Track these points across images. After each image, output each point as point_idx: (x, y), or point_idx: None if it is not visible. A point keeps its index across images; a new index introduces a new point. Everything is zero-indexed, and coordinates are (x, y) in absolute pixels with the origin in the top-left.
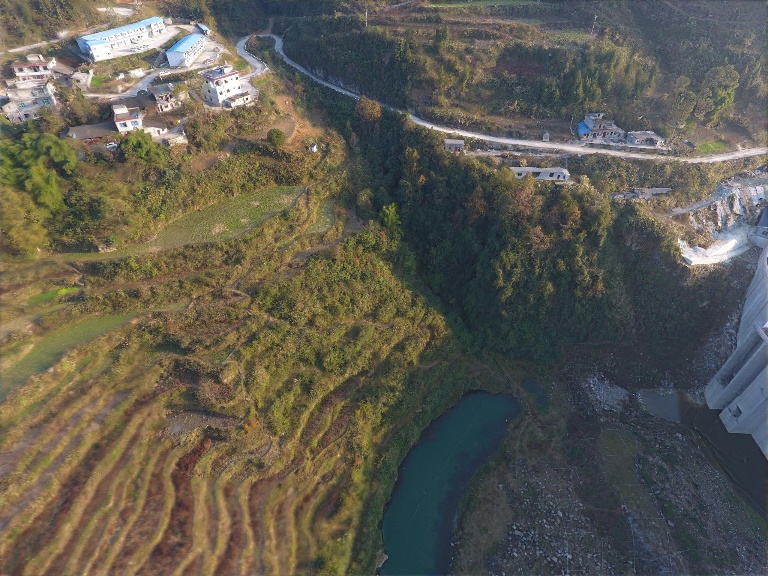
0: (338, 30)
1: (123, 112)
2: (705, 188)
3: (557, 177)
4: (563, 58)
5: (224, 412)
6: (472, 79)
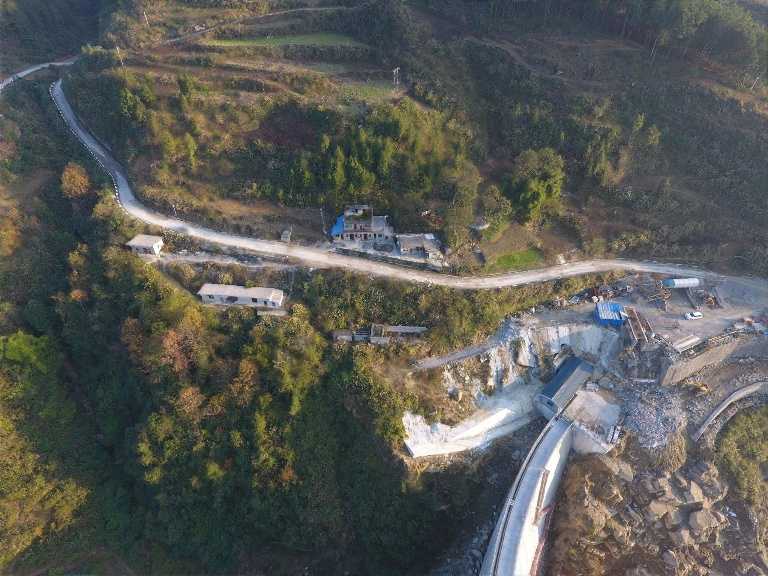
0: (95, 69)
1: None
2: (480, 327)
3: (264, 303)
4: (336, 125)
5: None
6: (211, 148)
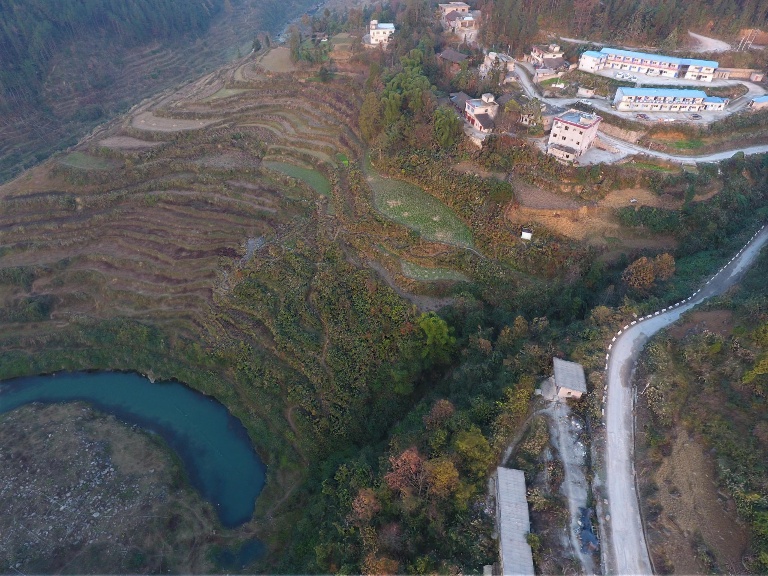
0: None
1: (485, 101)
2: None
3: None
4: None
5: (251, 257)
6: None
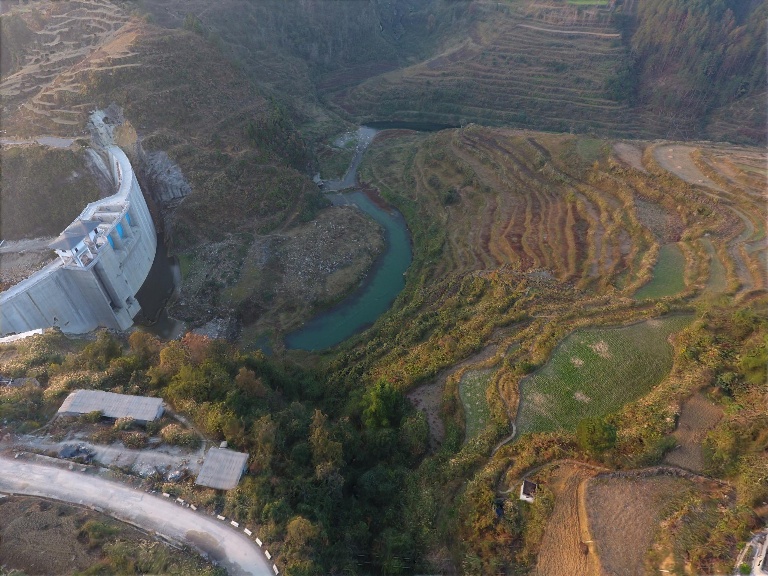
0: None
1: None
2: None
3: None
4: None
5: None
6: None
